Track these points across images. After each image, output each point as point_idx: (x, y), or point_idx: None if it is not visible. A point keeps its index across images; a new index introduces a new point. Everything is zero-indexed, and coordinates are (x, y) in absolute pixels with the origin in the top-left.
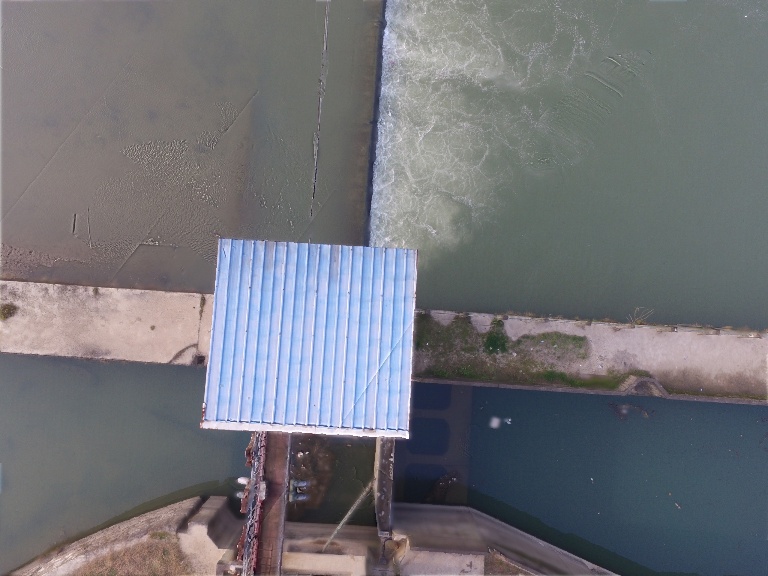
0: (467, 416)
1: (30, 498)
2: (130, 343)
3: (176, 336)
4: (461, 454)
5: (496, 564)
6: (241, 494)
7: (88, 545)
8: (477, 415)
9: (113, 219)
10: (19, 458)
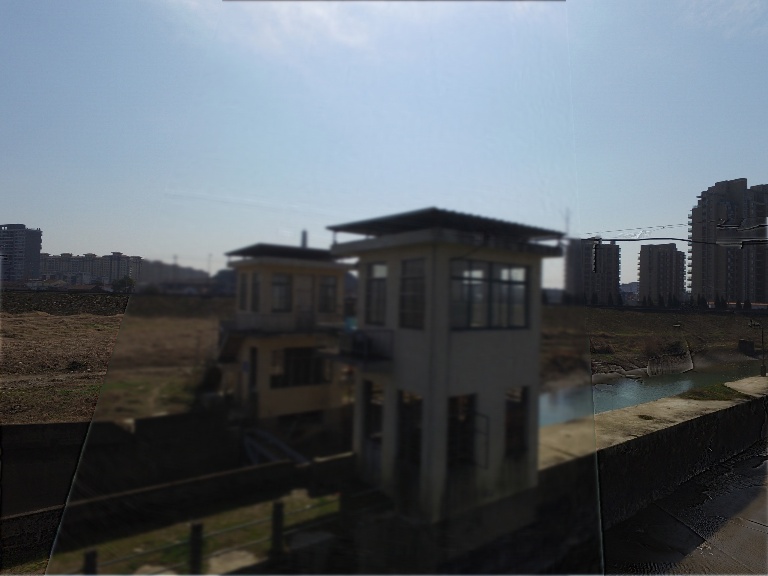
0: None
1: None
2: None
3: None
4: None
5: None
6: None
7: None
8: None
9: (760, 543)
10: None
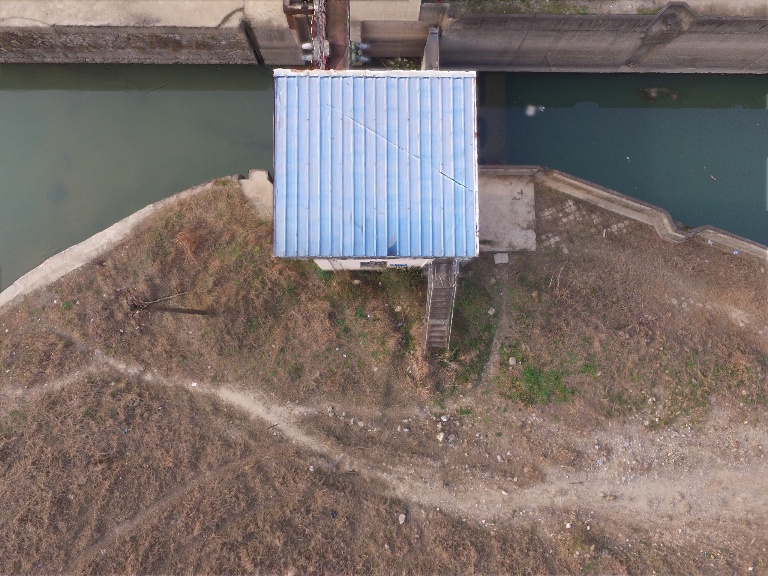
0: (502, 111)
1: (89, 206)
2: (179, 11)
3: (222, 2)
4: (499, 146)
5: (545, 192)
6: (306, 56)
7: None
8: (512, 109)
9: None
10: (76, 170)
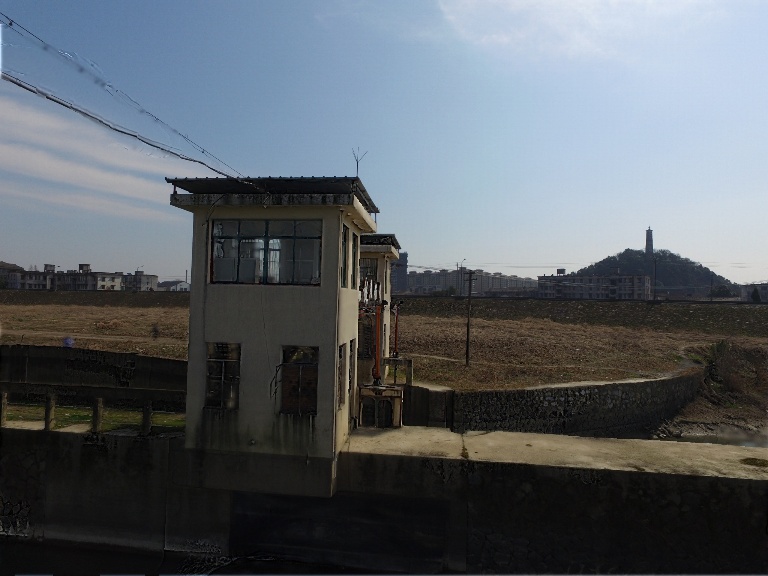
0: None
1: None
2: None
3: None
4: None
5: None
6: None
7: (533, 405)
8: None
9: None
10: None
